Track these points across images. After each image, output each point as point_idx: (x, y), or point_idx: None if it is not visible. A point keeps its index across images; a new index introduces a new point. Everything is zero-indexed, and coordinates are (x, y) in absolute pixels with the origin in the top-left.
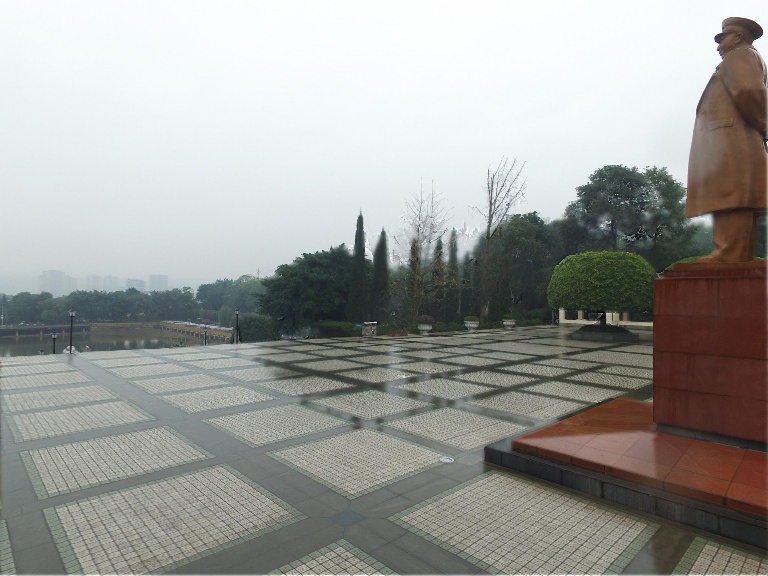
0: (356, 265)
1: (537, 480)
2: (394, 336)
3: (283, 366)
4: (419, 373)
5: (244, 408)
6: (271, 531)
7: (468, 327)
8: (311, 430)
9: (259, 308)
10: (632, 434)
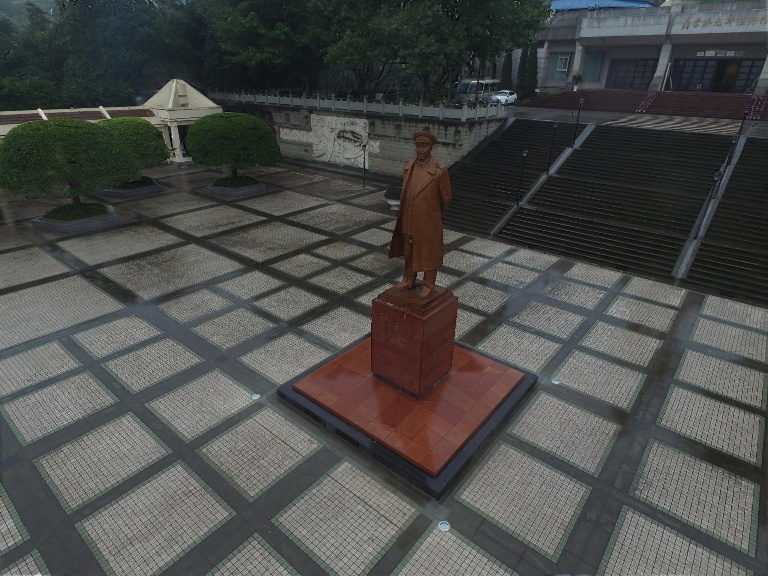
0: None
1: (463, 476)
2: None
3: None
4: (11, 558)
5: None
6: None
7: None
8: None
9: None
10: (424, 411)
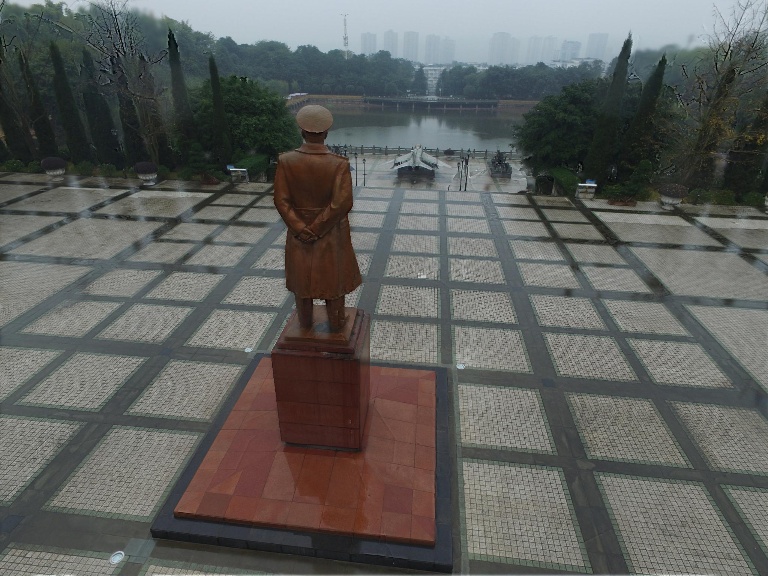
0: (606, 109)
1: None
2: (613, 204)
3: (384, 235)
4: (444, 276)
5: (273, 274)
6: (146, 343)
7: (767, 206)
8: (257, 303)
9: (512, 143)
10: None
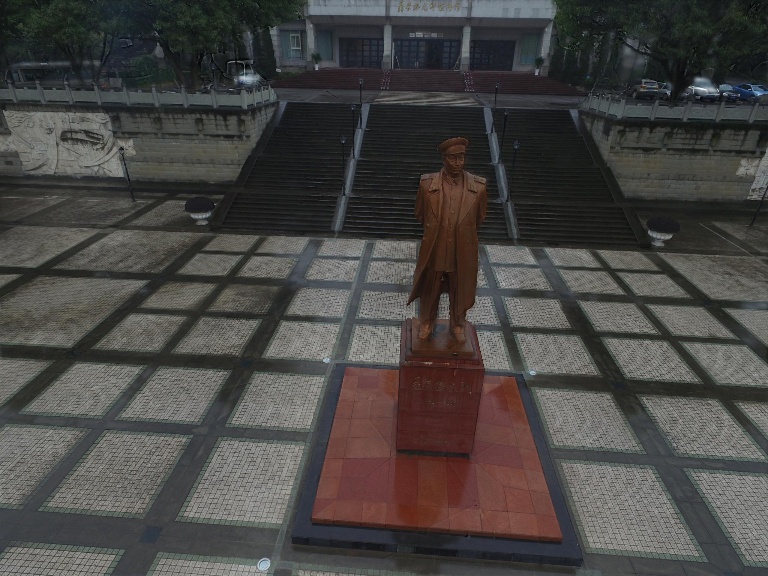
0: None
1: None
2: None
3: None
4: None
5: None
6: None
7: None
8: None
9: None
10: (487, 468)
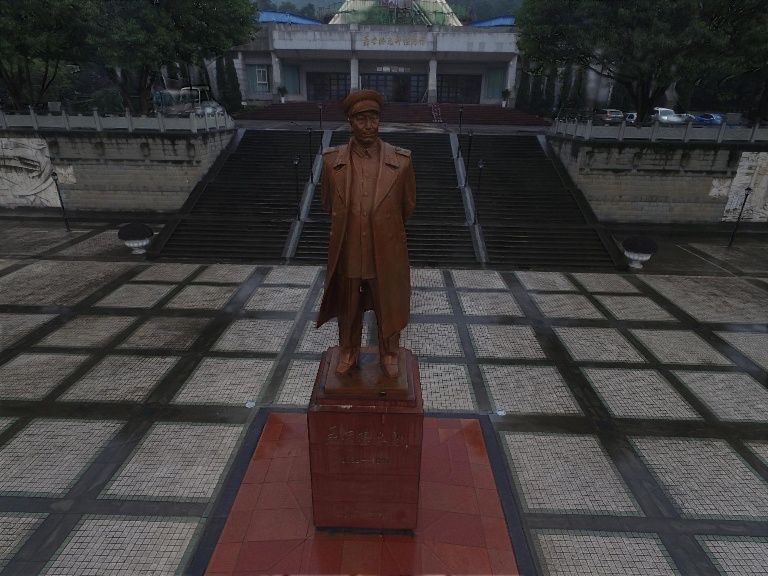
0: None
1: None
2: None
3: None
4: None
5: None
6: None
7: None
8: None
9: None
10: (437, 549)
